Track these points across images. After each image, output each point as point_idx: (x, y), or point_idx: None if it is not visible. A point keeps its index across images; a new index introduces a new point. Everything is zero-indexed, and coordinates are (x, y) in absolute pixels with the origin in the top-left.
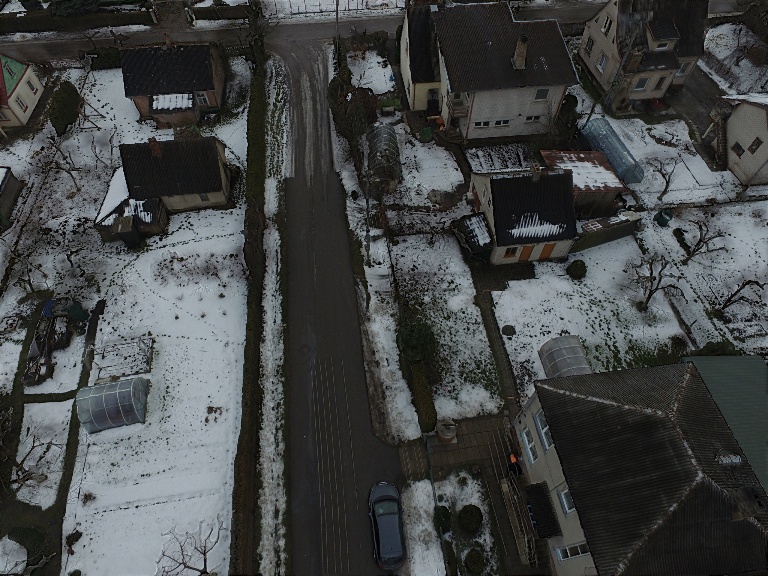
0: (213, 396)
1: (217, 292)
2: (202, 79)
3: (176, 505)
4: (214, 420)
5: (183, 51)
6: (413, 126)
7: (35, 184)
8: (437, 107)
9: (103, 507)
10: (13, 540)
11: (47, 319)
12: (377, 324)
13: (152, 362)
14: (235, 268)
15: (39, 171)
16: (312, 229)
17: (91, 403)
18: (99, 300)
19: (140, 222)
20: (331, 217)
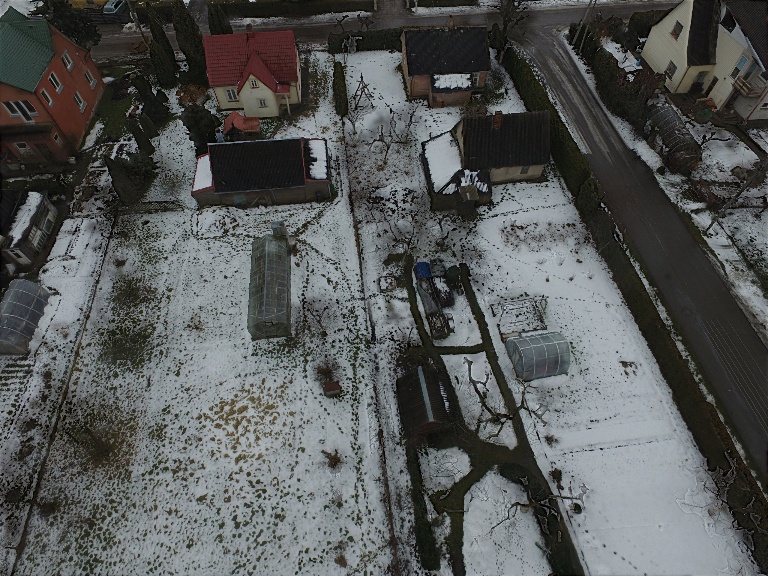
0: (620, 352)
1: (572, 258)
2: (480, 60)
3: (639, 448)
4: (633, 373)
5: (463, 33)
6: (682, 108)
7: (340, 157)
8: (701, 90)
9: (568, 448)
10: (512, 474)
11: (426, 279)
12: (744, 290)
13: (544, 320)
14: (579, 236)
15: (336, 145)
16: (636, 202)
17: (535, 352)
18: (459, 263)
19: (478, 191)
20: (648, 191)
